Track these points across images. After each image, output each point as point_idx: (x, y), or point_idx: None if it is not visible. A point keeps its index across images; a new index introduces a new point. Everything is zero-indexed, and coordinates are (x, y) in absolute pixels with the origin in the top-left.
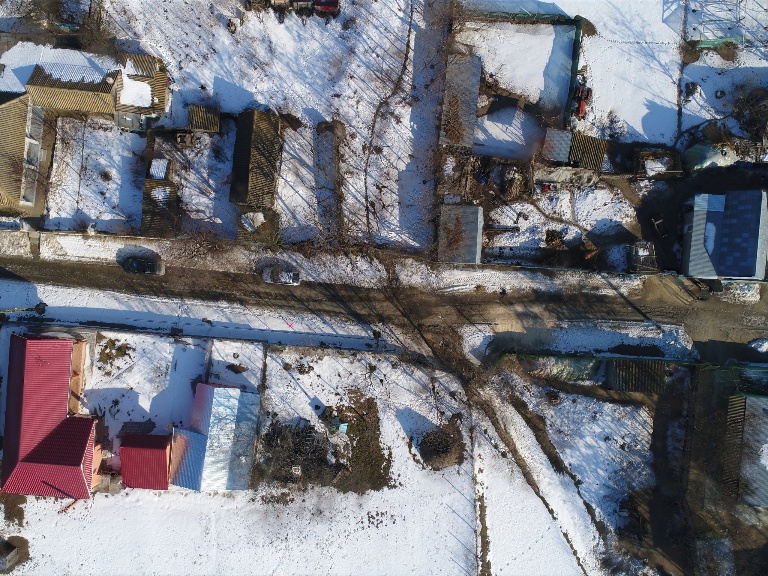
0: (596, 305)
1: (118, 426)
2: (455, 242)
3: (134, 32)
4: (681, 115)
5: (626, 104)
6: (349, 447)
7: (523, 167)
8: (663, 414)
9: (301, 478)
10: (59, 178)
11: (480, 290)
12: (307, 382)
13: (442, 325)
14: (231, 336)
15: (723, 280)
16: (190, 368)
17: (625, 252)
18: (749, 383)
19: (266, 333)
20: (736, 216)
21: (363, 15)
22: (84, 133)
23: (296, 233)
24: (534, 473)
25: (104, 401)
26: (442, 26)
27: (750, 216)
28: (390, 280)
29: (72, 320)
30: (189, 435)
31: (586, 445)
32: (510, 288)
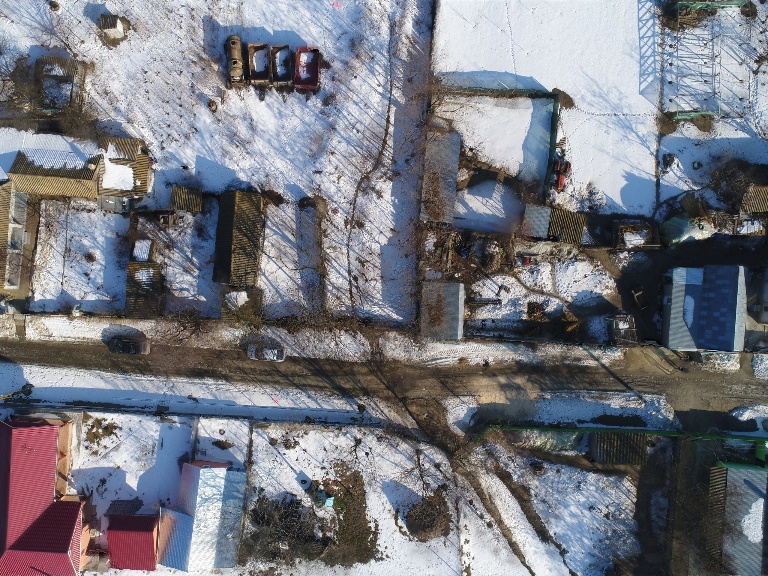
0: (578, 376)
1: (106, 505)
2: (437, 318)
3: (116, 113)
4: (659, 186)
5: (605, 176)
6: (336, 520)
7: (503, 242)
8: (646, 483)
9: (288, 552)
10: (43, 260)
11: (463, 362)
12: (293, 457)
13: (426, 397)
14: (217, 413)
15: (703, 352)
16: (176, 446)
17: (606, 323)
18: (731, 452)
19: (252, 409)
20: (714, 290)
21: (343, 91)
22: (68, 215)
23: (280, 309)
24: (520, 543)
25: (91, 480)
26: (421, 101)
27: (728, 291)
28: (374, 354)
29: (58, 400)
30: (176, 515)
31: (571, 514)
32: (493, 360)
